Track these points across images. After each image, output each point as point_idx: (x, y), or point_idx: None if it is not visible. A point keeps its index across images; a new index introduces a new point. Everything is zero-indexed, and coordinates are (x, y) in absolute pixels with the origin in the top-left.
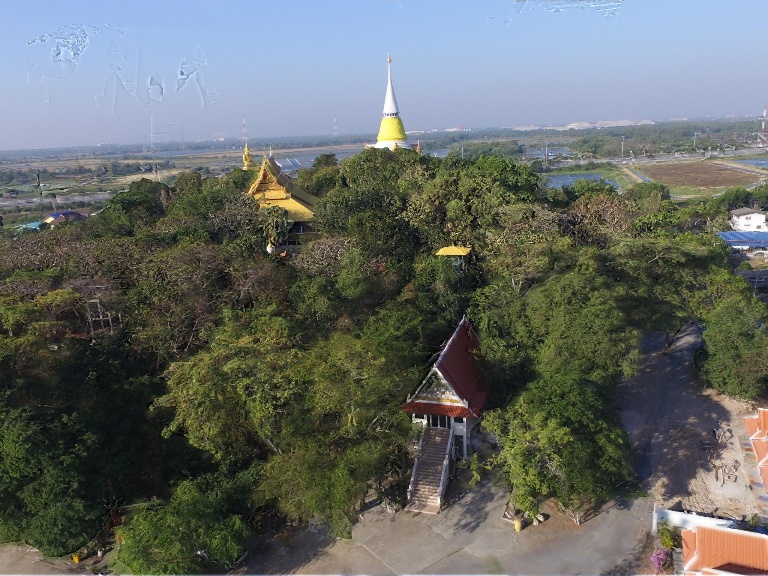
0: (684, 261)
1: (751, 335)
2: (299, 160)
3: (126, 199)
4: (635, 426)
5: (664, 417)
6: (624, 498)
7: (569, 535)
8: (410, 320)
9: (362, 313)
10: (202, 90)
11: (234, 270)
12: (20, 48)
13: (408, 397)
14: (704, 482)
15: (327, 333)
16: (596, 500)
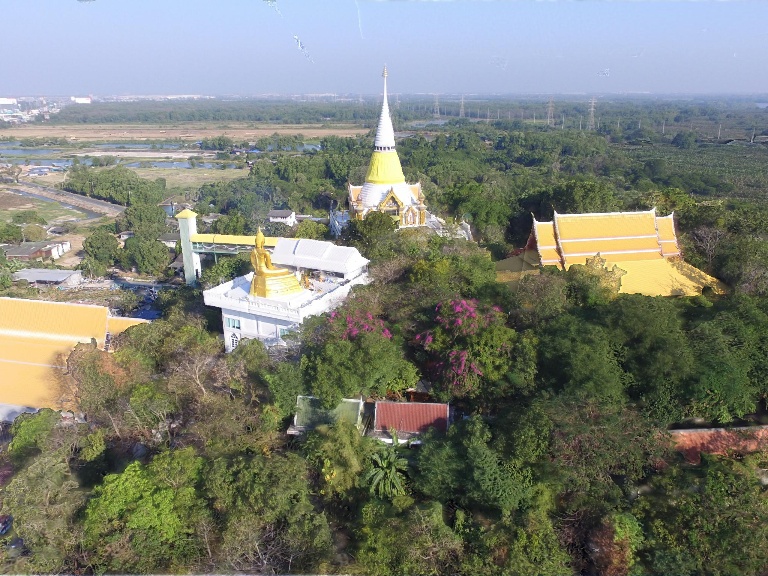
0: None
1: None
2: None
3: None
4: None
5: None
6: None
7: None
8: None
9: None
10: None
11: None
12: None
13: None
14: None
15: None
16: None
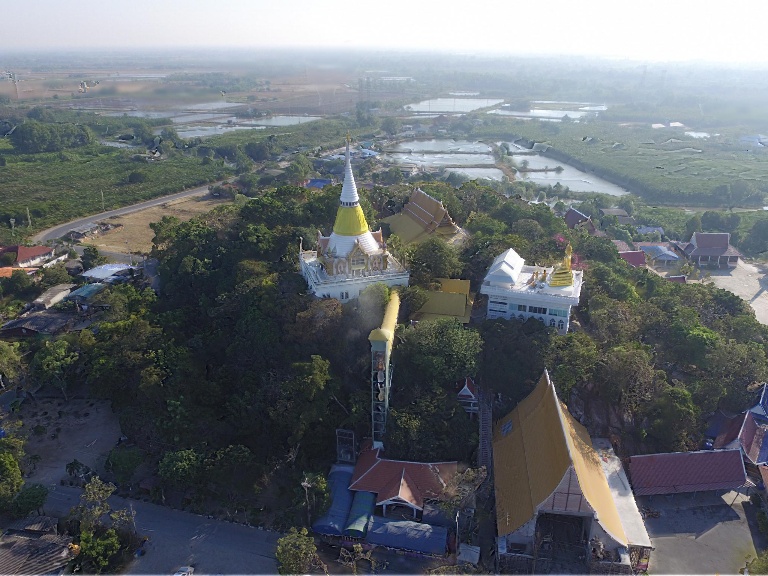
0: None
1: None
2: None
3: (484, 195)
4: None
5: None
6: None
7: None
8: None
9: None
10: None
11: None
12: None
13: None
14: None
15: None
16: None
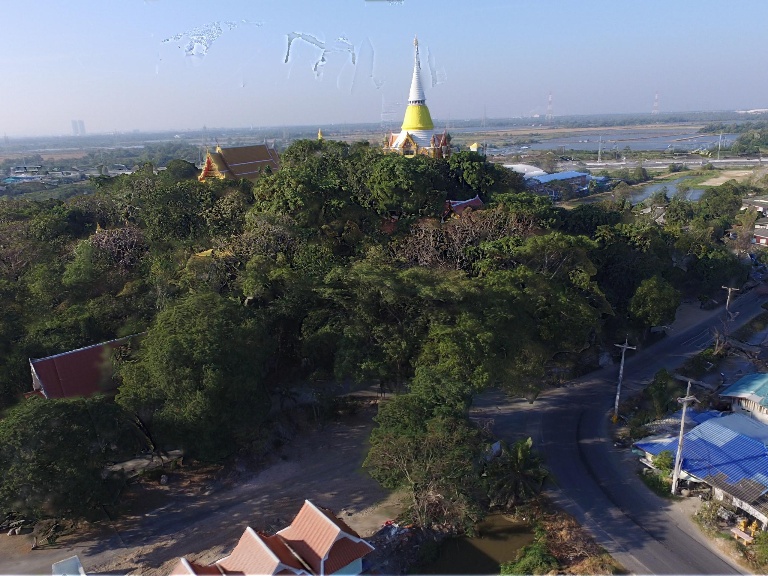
0: (390, 301)
1: (426, 412)
2: (567, 141)
3: (103, 178)
4: (265, 480)
5: (309, 481)
6: (108, 543)
7: (6, 555)
8: (78, 315)
9: (84, 301)
10: (432, 71)
11: (3, 247)
12: (152, 46)
13: (33, 385)
14: (195, 560)
15: (42, 314)
16: (87, 535)
